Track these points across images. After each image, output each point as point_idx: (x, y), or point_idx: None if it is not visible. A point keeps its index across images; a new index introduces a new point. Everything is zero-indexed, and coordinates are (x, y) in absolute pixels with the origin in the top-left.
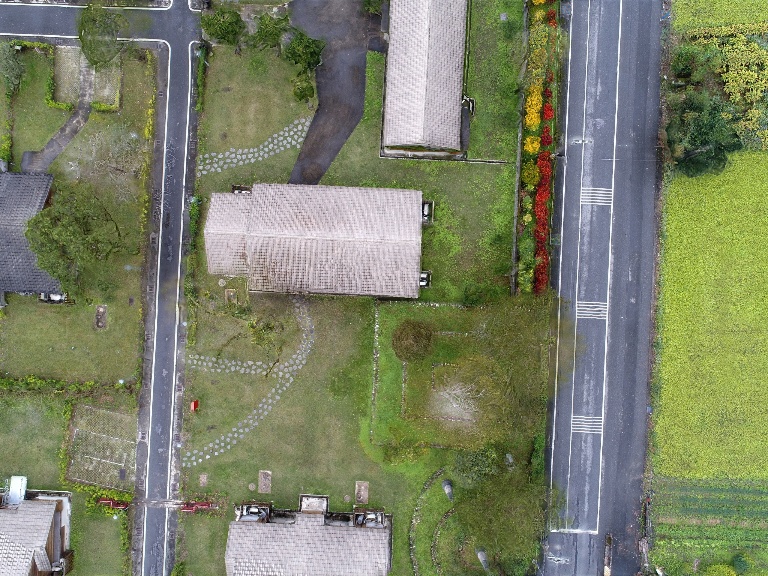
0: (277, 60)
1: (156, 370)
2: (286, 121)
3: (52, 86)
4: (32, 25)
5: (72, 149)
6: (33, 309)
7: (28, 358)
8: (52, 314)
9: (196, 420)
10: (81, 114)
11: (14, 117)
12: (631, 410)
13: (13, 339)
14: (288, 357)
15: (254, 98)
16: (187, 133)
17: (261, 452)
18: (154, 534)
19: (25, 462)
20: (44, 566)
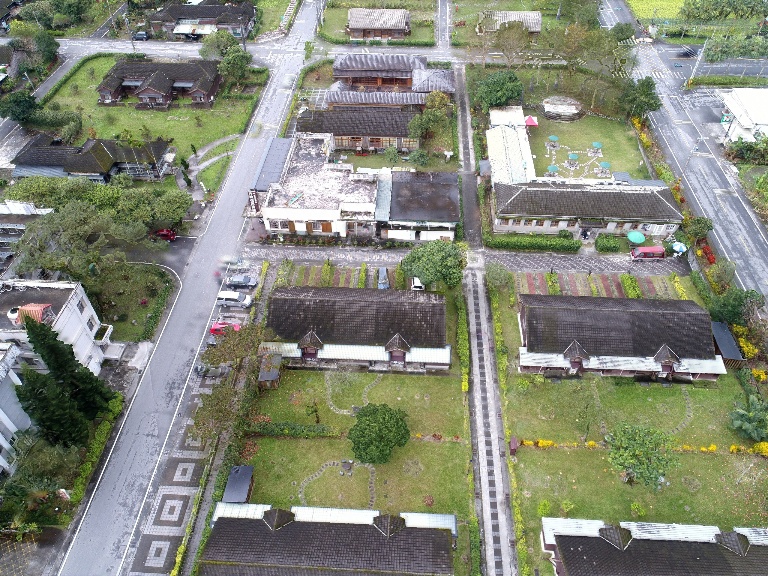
0: None
1: (440, 6)
2: None
3: None
4: None
5: None
6: None
7: None
8: None
9: None
10: None
11: None
12: (621, 8)
13: None
14: None
15: None
16: None
17: None
18: None
19: None
20: (407, 19)
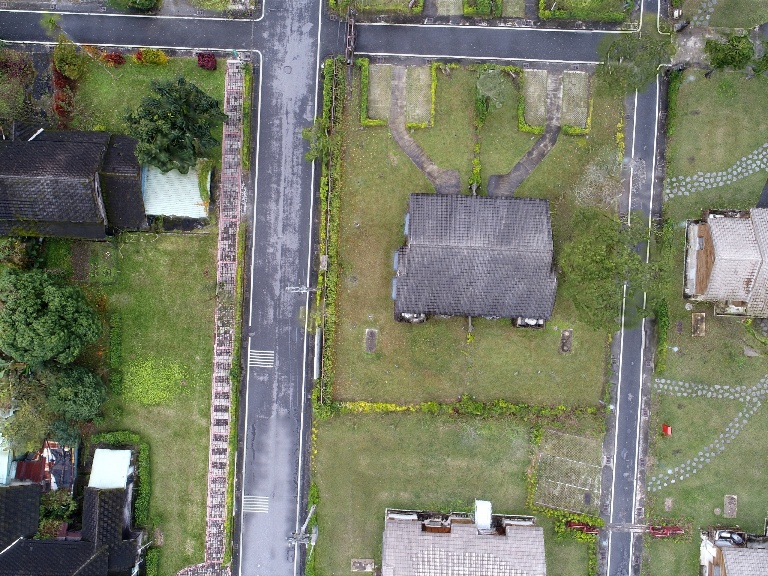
0: (747, 83)
1: (622, 394)
2: (755, 144)
3: (524, 110)
4: (499, 48)
5: (539, 173)
6: (498, 333)
7: (493, 382)
8: (518, 338)
9: (662, 444)
10: (548, 137)
11: (481, 141)
12: None
13: (478, 363)
14: (756, 381)
15: (722, 121)
16: (654, 156)
17: (727, 476)
18: (619, 559)
19: (489, 487)
20: None
